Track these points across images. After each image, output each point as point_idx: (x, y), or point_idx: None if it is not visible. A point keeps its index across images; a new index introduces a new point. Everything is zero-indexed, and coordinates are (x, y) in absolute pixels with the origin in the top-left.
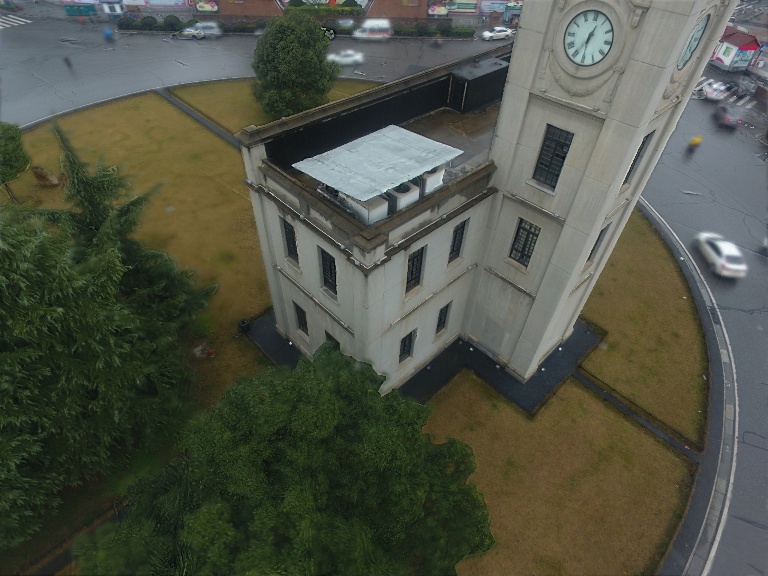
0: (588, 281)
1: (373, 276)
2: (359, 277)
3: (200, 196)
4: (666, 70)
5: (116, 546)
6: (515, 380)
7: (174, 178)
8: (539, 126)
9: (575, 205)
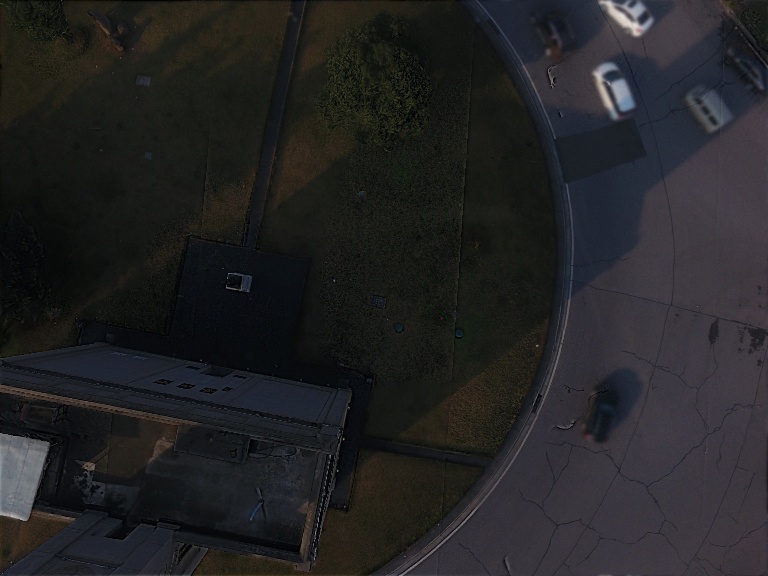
0: None
1: None
2: None
3: (179, 160)
4: None
5: None
6: None
7: (184, 114)
8: None
9: None
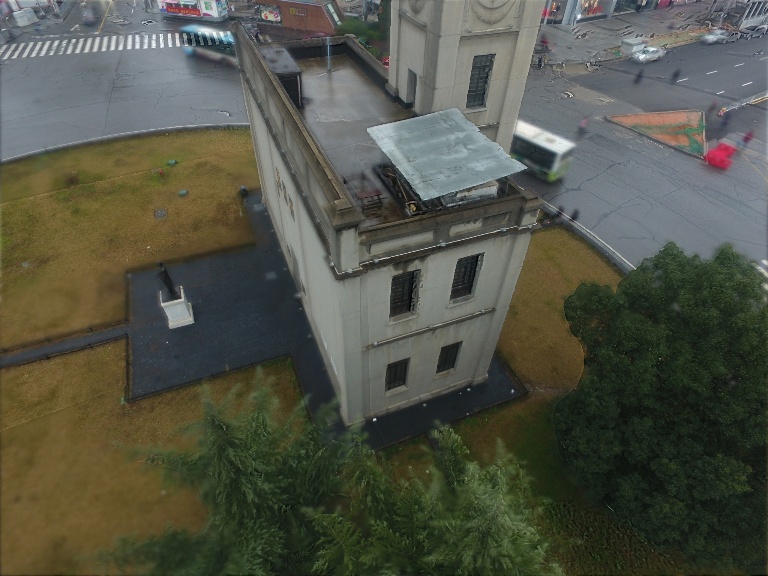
0: None
1: None
2: (523, 241)
3: None
4: None
5: None
6: None
7: None
8: (468, 61)
9: (506, 106)
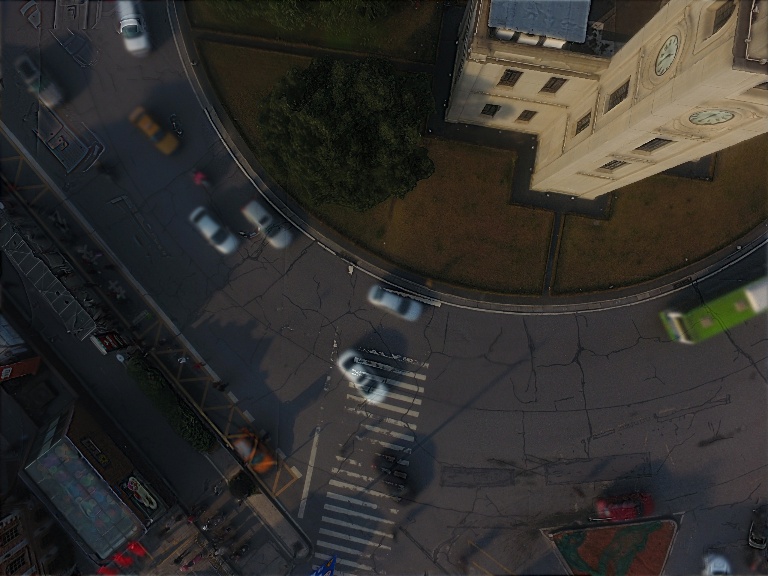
0: (610, 181)
1: (473, 64)
2: None
3: None
4: (656, 116)
5: (299, 79)
6: (528, 184)
7: None
8: (629, 72)
9: (598, 132)
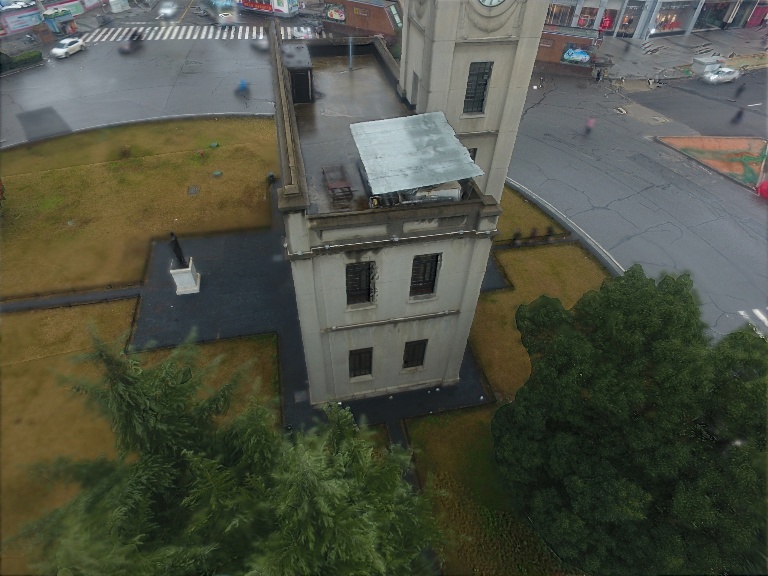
0: None
1: None
2: (483, 246)
3: None
4: None
5: (760, 464)
6: None
7: None
8: (465, 68)
9: (505, 114)
